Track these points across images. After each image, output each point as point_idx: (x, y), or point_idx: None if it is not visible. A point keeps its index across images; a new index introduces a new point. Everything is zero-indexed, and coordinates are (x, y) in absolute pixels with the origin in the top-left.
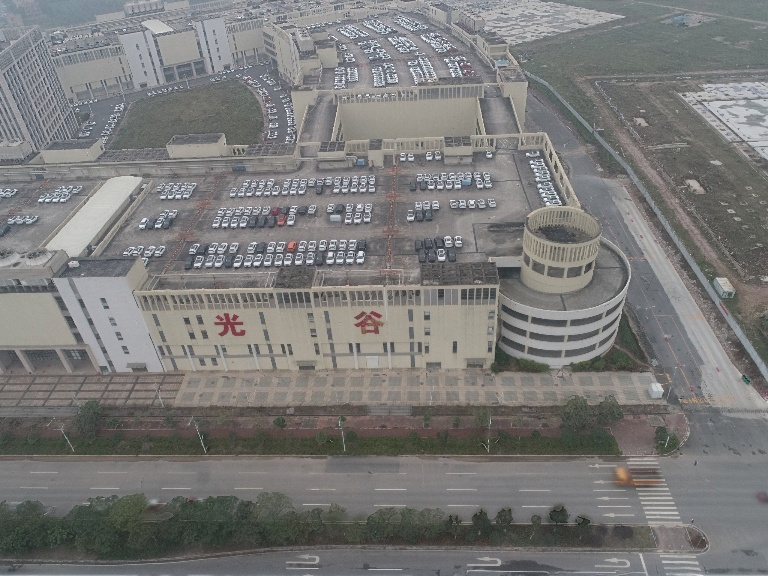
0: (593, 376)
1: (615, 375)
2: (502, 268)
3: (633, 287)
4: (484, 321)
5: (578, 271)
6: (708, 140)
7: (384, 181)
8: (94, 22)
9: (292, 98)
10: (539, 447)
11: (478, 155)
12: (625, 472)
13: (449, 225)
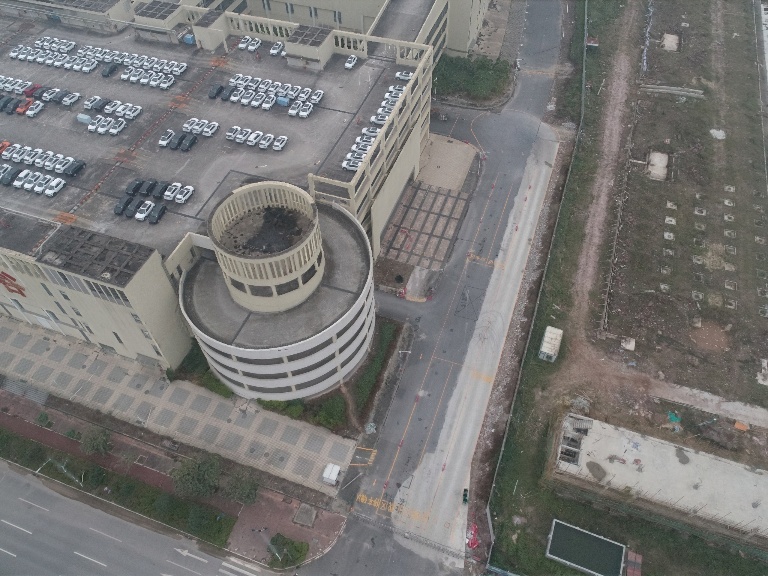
0: (282, 423)
1: (309, 430)
2: (209, 250)
3: (441, 304)
4: (133, 322)
5: (284, 286)
6: (738, 93)
7: (194, 74)
8: None
9: None
10: (140, 502)
11: (340, 60)
12: (209, 575)
13: (201, 164)
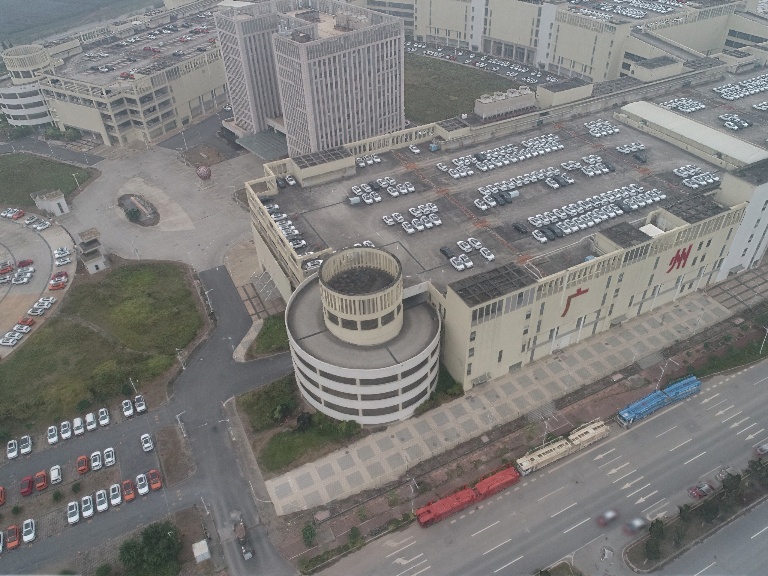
0: None
1: None
2: None
3: None
4: None
5: None
6: None
7: None
8: (163, 8)
9: (617, 31)
10: None
11: None
12: None
13: None
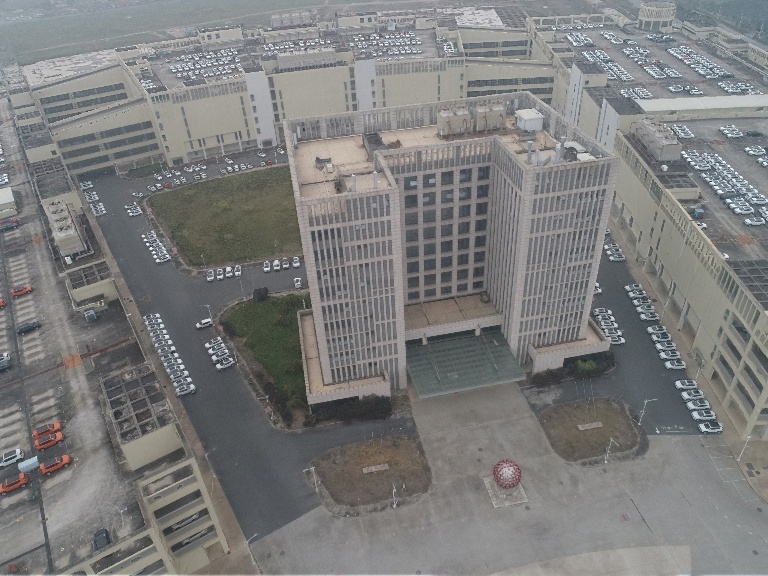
0: None
1: None
2: None
3: None
4: None
5: None
6: None
7: None
8: None
9: None
10: None
11: None
12: None
13: (634, 39)
